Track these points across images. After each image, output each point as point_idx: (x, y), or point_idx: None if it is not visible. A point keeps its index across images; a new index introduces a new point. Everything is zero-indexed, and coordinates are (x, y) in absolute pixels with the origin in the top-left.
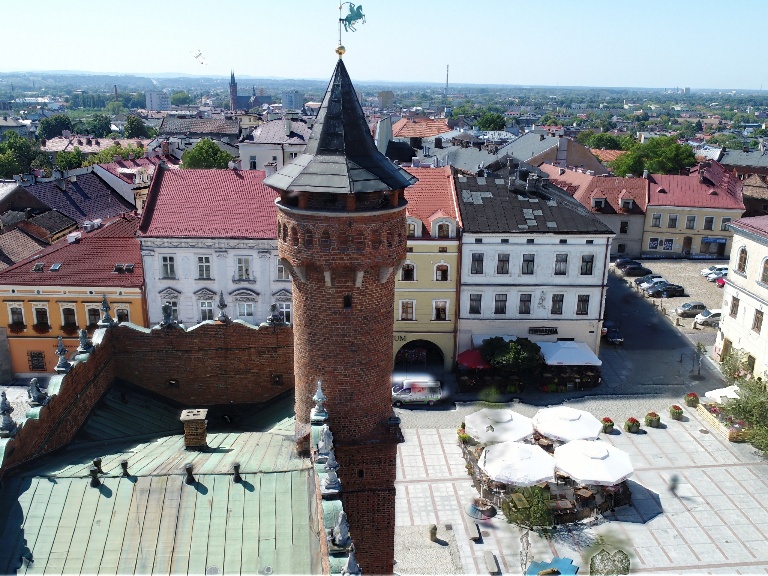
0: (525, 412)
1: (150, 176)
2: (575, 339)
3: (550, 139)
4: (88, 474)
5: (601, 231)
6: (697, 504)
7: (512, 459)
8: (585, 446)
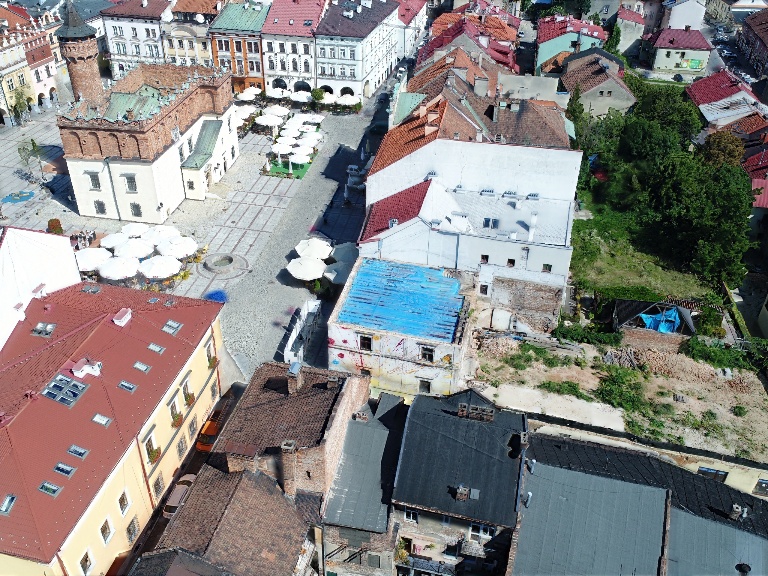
0: None
1: None
2: None
3: None
4: None
5: None
6: None
7: None
8: None
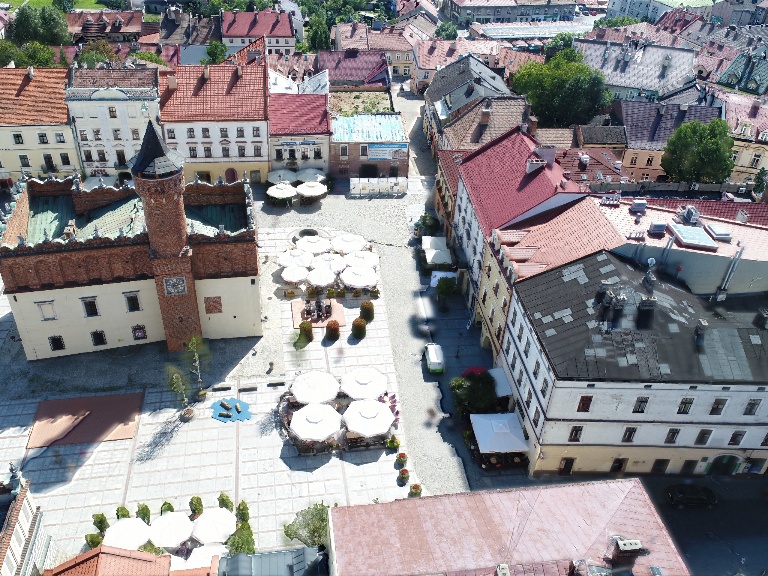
0: (426, 418)
1: (759, 131)
2: (529, 439)
3: None
4: (142, 206)
5: (555, 368)
6: (300, 490)
7: (308, 379)
8: (318, 410)
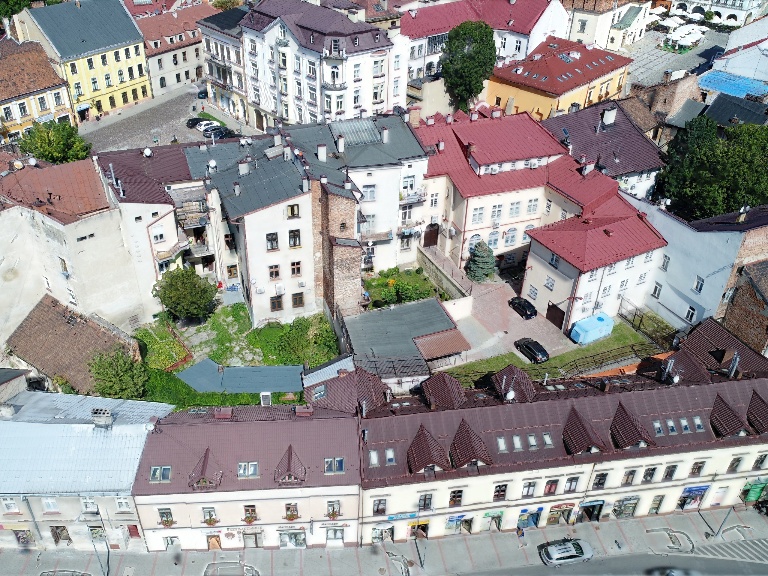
0: None
1: None
2: None
3: (90, 1)
4: None
5: None
6: None
7: None
8: None
